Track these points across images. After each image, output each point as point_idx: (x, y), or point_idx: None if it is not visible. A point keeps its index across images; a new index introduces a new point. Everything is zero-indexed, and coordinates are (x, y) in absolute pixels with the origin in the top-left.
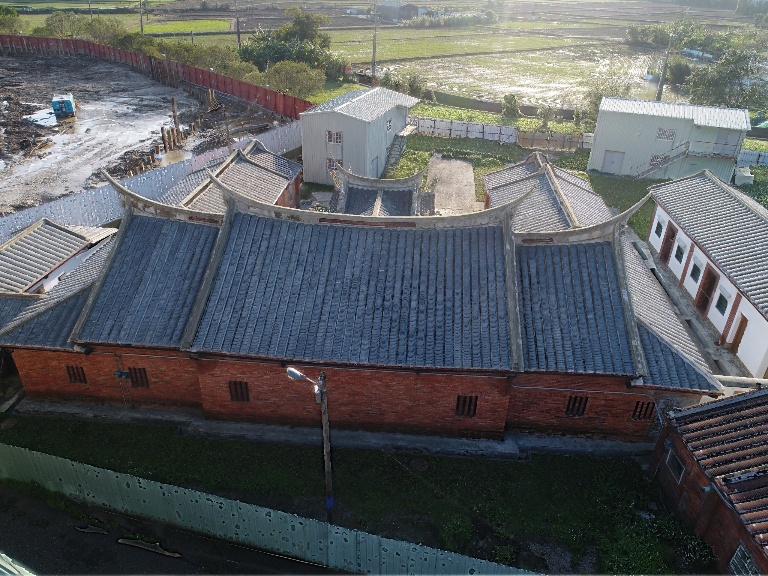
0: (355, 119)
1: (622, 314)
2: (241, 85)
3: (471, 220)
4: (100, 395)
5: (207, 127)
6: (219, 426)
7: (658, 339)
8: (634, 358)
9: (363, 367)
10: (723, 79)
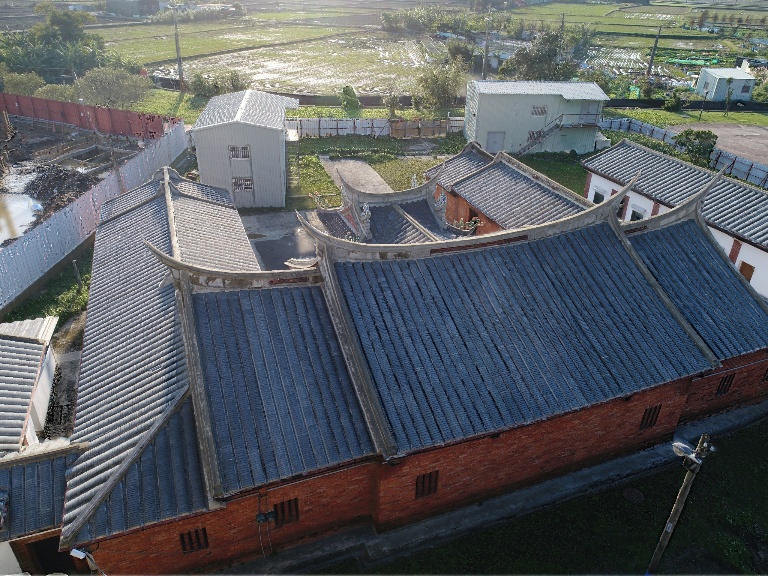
0: (264, 128)
1: (742, 286)
2: (34, 102)
3: (579, 221)
4: (226, 555)
5: (18, 160)
6: (401, 535)
7: (767, 302)
8: None
9: (581, 410)
10: (545, 56)
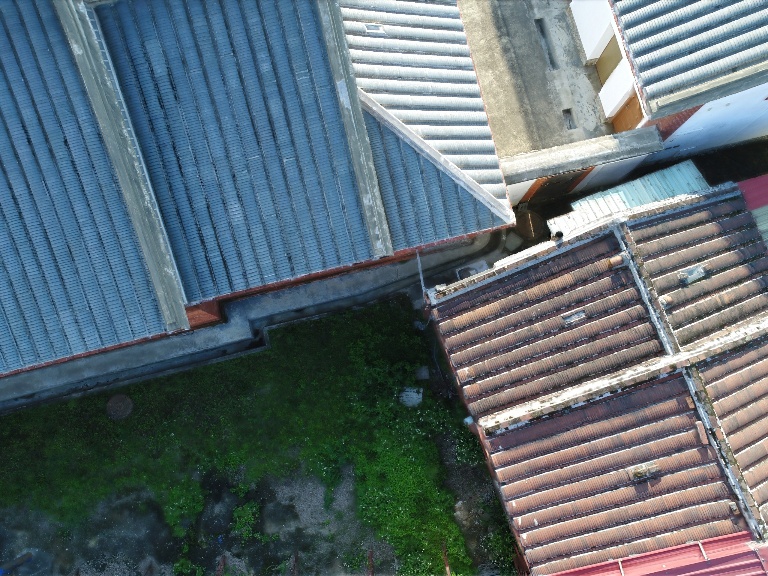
0: None
1: (343, 138)
2: None
3: None
4: None
5: None
6: None
7: (414, 149)
8: (369, 231)
9: None
10: None
